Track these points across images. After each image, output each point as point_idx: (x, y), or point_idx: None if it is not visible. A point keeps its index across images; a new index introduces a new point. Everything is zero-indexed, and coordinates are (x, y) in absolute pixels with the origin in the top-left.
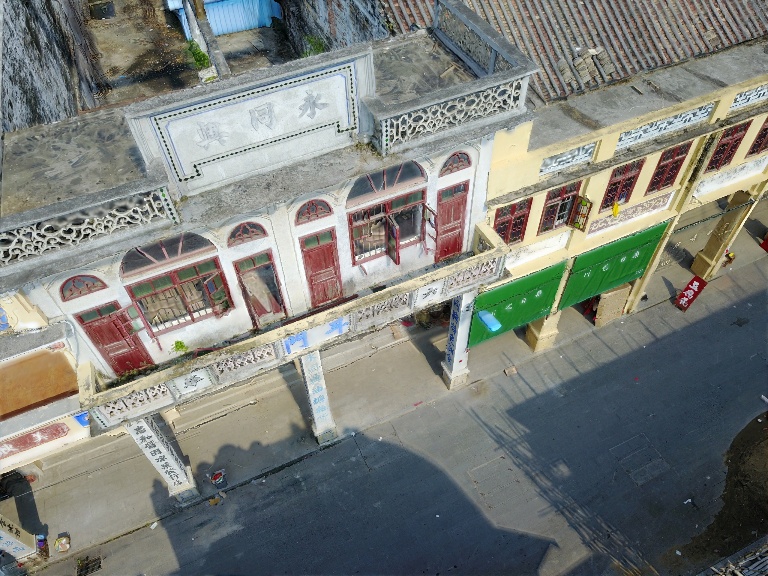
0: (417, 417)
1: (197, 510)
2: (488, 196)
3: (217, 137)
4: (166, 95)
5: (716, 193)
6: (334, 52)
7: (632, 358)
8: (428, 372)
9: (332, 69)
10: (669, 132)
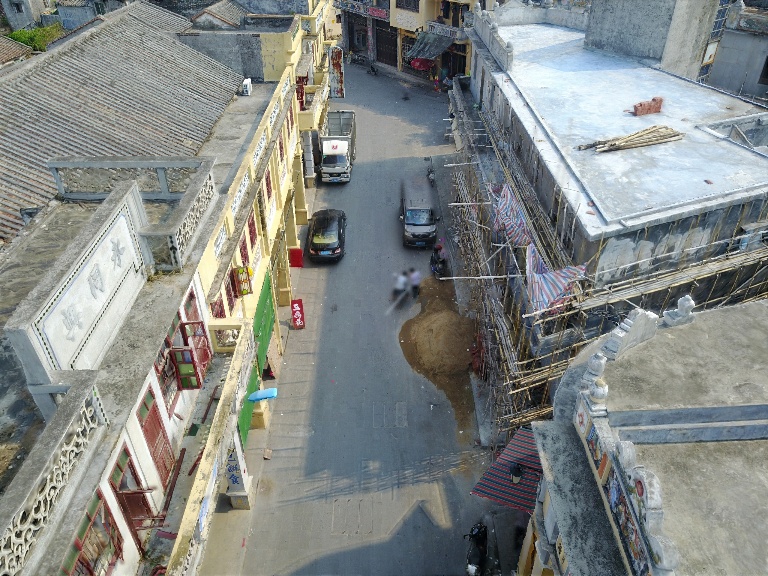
0: (254, 552)
1: None
2: (205, 294)
3: (77, 321)
4: (31, 293)
5: (272, 234)
6: (111, 196)
7: (316, 375)
8: (219, 518)
9: (118, 211)
10: (242, 198)
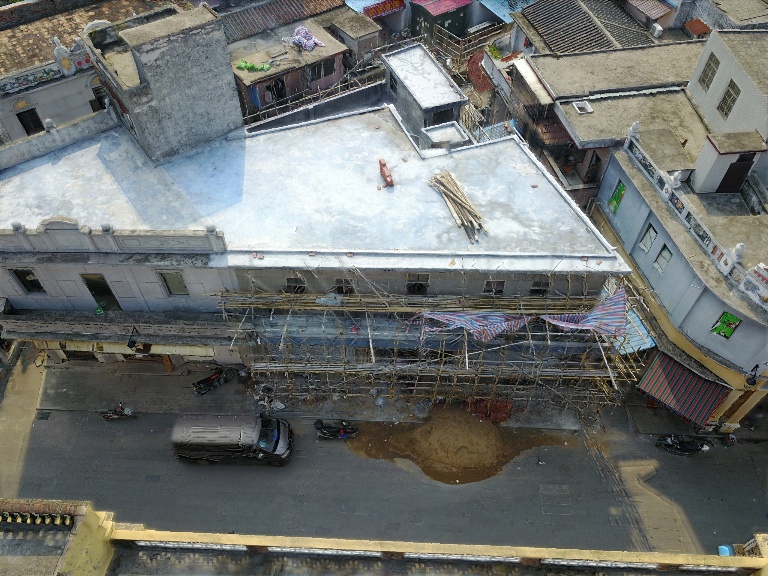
0: None
1: None
2: None
3: None
4: None
5: None
6: None
7: None
8: None
9: None
10: None
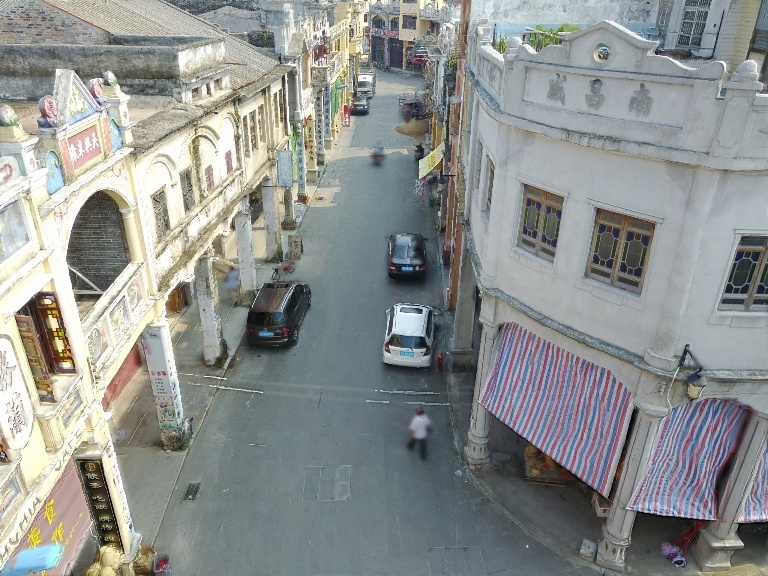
0: None
1: (322, 183)
2: None
3: None
4: None
5: None
6: None
7: None
8: None
9: None
10: None
